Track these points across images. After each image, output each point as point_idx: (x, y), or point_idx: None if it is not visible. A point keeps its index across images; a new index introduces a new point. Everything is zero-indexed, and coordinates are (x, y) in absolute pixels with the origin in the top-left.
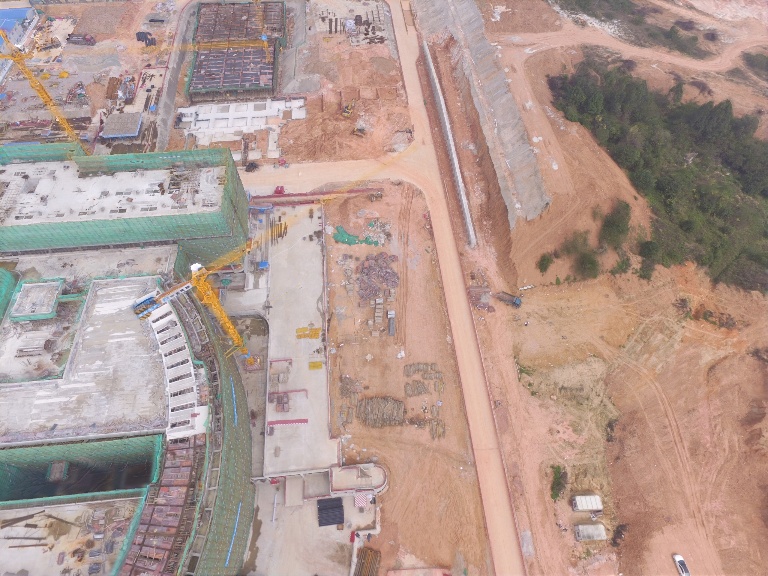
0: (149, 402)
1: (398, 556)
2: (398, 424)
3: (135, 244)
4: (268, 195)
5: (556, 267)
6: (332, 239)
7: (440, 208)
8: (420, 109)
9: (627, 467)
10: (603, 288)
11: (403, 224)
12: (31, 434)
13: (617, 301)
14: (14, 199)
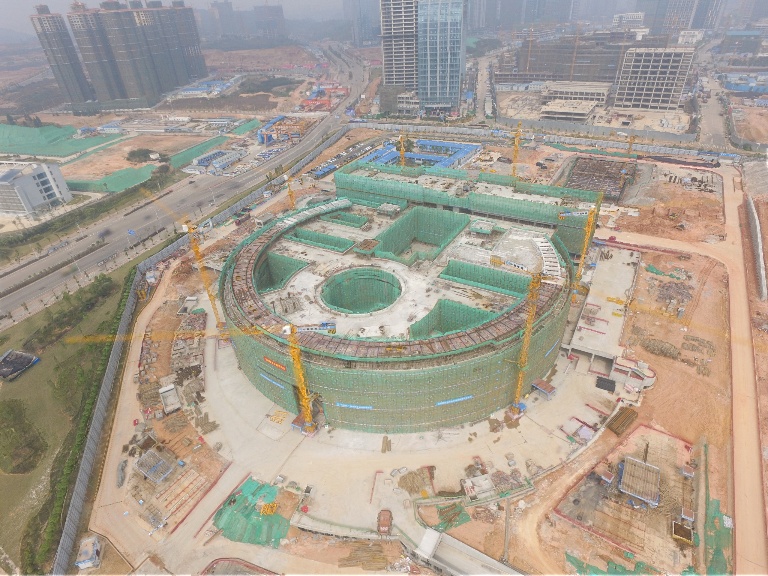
0: (533, 269)
1: (650, 423)
2: (672, 358)
3: (532, 224)
4: (604, 239)
5: None
6: (644, 269)
7: (738, 276)
8: (735, 228)
9: None
10: None
11: (703, 275)
12: (475, 262)
13: None
14: (481, 192)
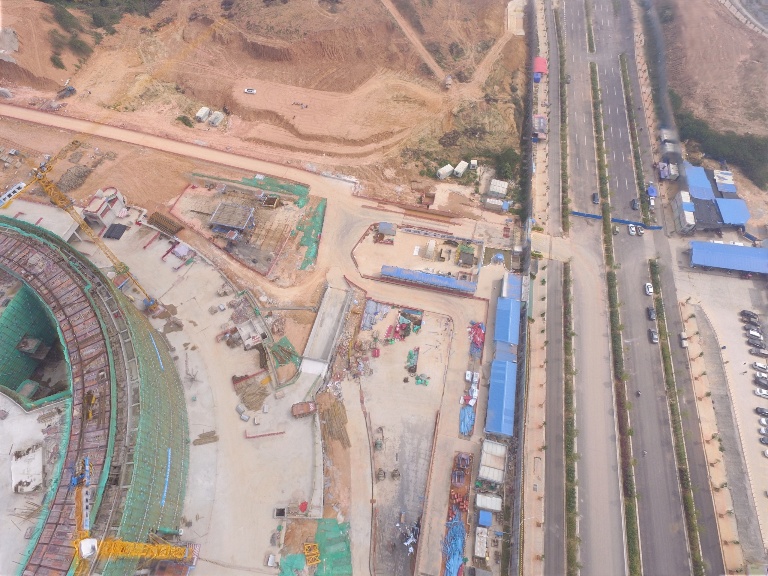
0: None
1: (166, 206)
2: (89, 173)
3: None
4: None
5: (66, 60)
6: None
7: None
8: None
9: (199, 90)
10: (104, 54)
11: None
12: None
13: (117, 52)
14: None
